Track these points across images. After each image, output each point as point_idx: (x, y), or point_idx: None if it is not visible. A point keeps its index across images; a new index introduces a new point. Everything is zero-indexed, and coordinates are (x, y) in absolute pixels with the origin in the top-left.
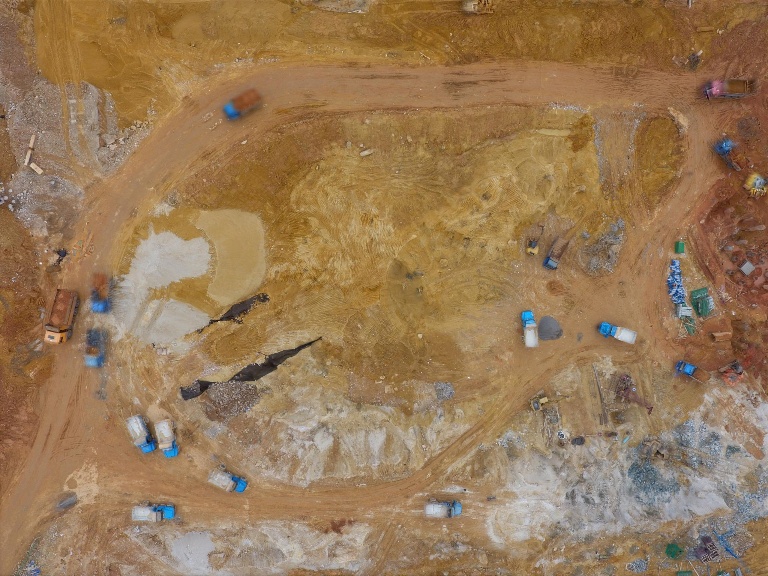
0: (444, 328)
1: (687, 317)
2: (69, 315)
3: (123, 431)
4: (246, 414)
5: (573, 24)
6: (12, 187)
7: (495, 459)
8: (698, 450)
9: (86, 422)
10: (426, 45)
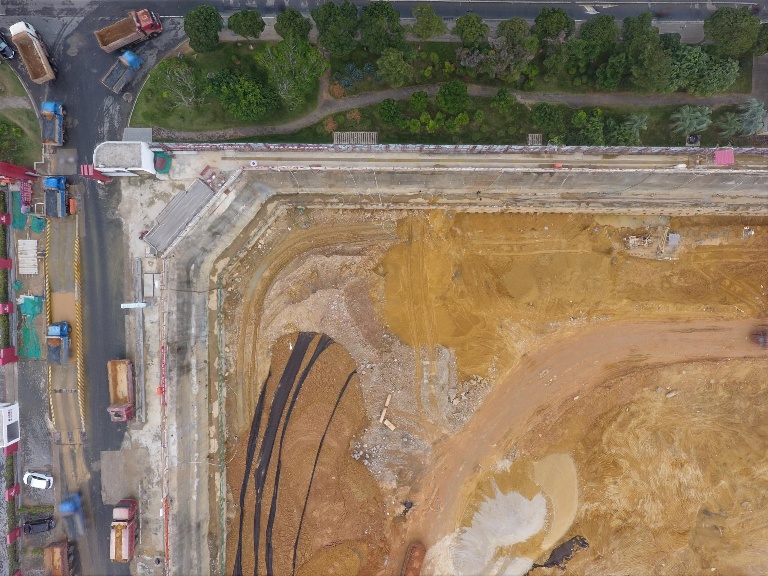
0: (736, 562)
1: None
2: (420, 570)
3: None
4: None
5: None
6: (366, 442)
7: None
8: None
9: None
10: (735, 295)
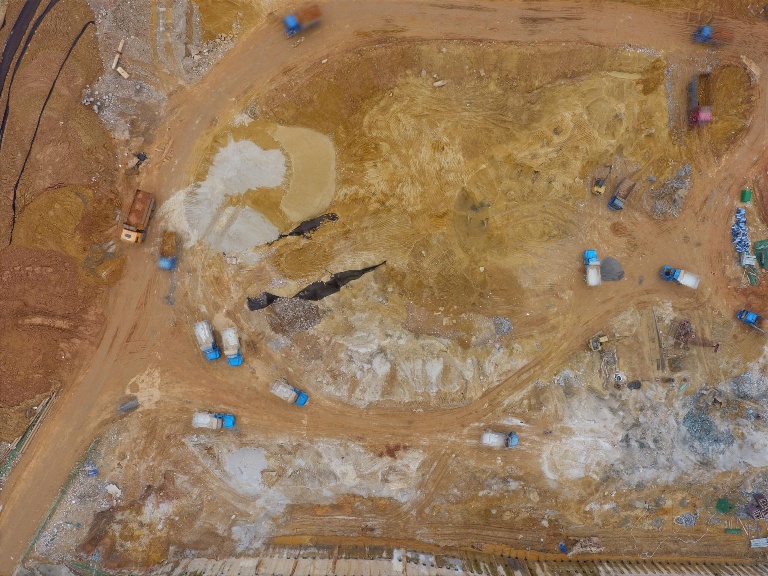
0: (506, 263)
1: (750, 266)
2: (146, 216)
3: (188, 338)
4: (308, 331)
5: None
6: (98, 89)
7: (551, 396)
8: (755, 403)
9: (152, 326)
10: None
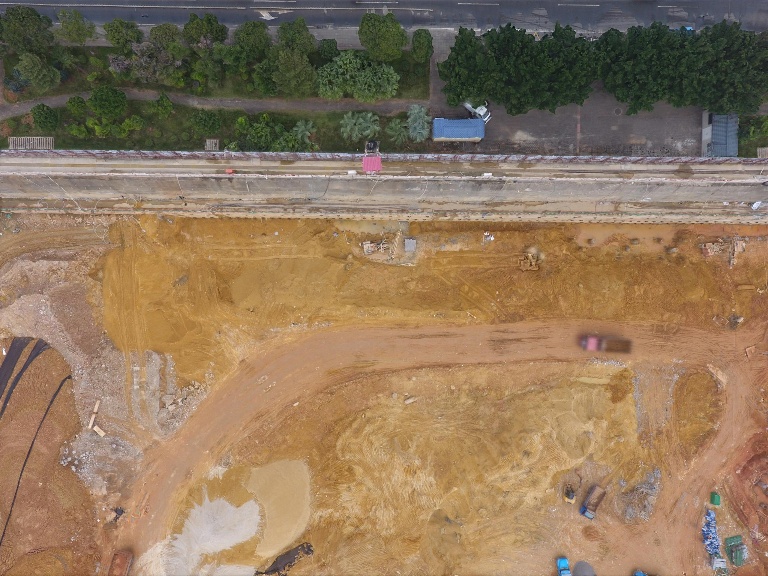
0: (480, 569)
1: (721, 568)
2: None
3: None
4: None
5: (617, 290)
6: (75, 448)
7: None
8: None
9: None
10: (472, 301)
